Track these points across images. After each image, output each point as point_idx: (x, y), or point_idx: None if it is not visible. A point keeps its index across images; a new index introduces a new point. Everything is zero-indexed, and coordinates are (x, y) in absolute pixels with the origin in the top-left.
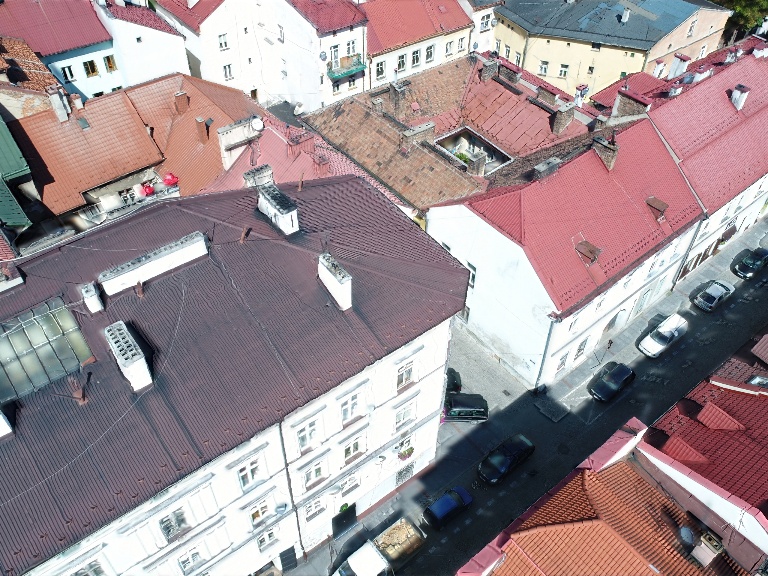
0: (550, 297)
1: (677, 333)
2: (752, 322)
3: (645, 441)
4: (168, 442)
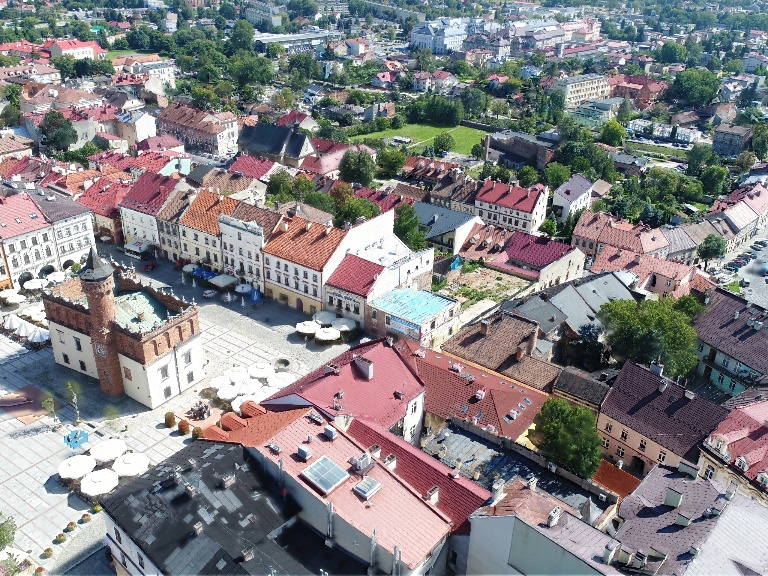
0: None
1: None
2: None
3: None
4: None
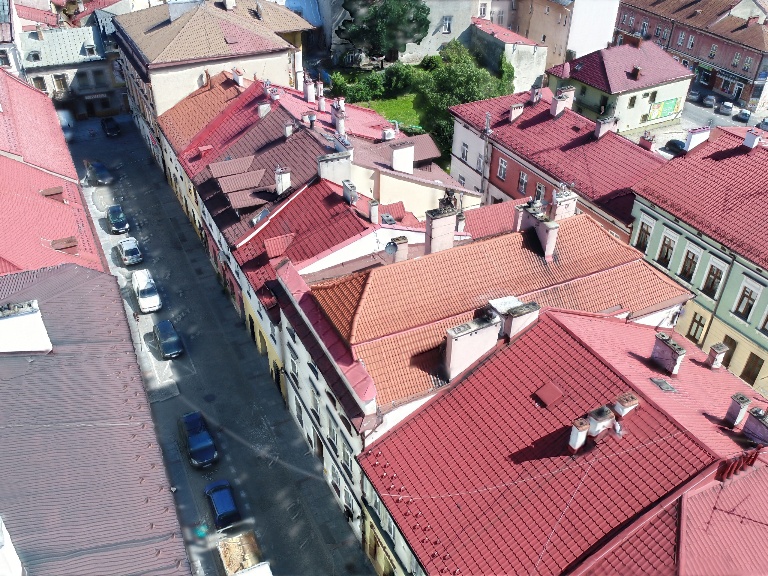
0: None
1: (153, 280)
2: (169, 245)
3: (267, 298)
4: (128, 570)
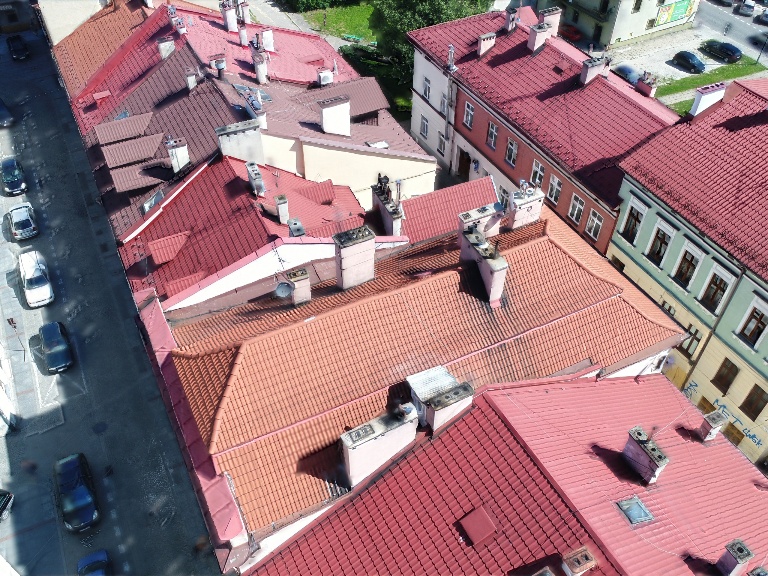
0: None
1: (42, 266)
2: (72, 211)
3: None
4: None
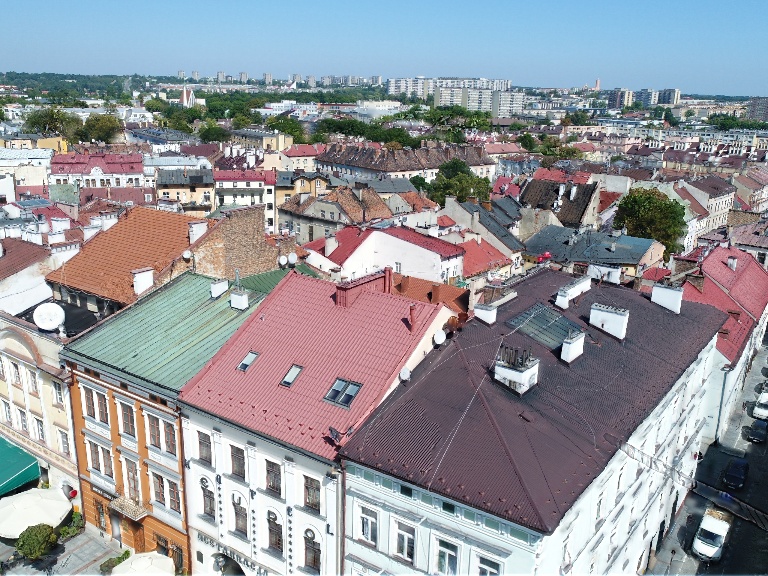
0: (722, 354)
1: None
2: None
3: None
4: None
